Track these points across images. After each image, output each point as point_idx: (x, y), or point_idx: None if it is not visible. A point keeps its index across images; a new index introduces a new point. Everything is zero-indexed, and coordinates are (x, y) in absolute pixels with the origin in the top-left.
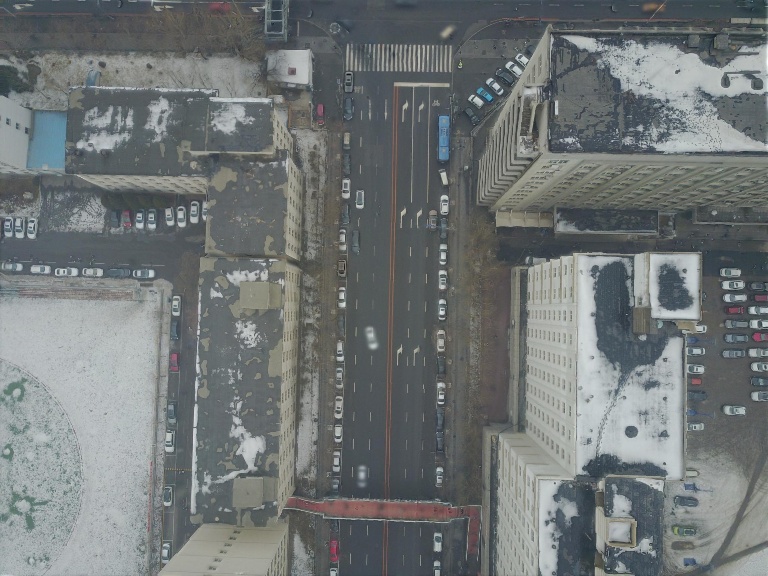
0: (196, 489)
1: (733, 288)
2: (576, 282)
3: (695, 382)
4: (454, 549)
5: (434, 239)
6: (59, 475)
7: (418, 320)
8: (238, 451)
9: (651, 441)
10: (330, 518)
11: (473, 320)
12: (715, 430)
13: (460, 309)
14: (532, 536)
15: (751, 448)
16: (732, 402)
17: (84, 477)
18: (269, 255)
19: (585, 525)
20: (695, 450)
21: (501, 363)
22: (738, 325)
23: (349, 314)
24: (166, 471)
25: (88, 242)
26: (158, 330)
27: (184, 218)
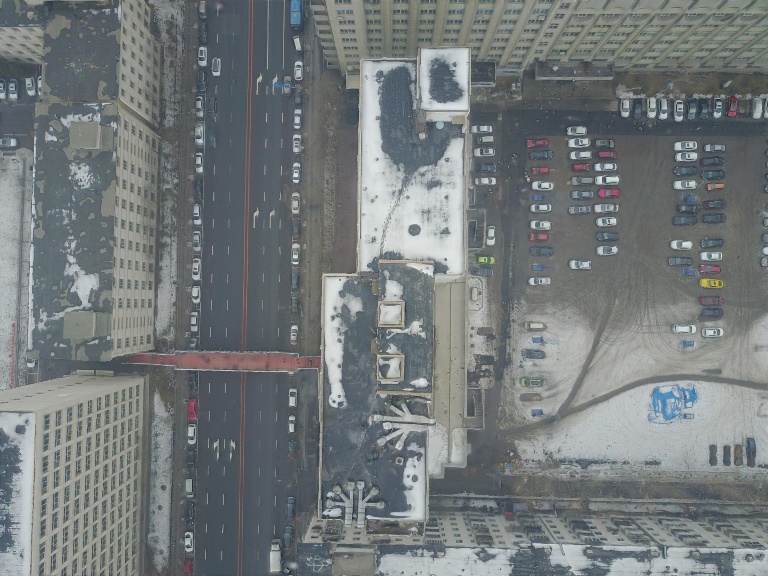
0: (32, 326)
1: (578, 145)
2: (360, 86)
3: (541, 237)
4: (309, 404)
5: (290, 105)
6: None
7: (274, 184)
8: (72, 288)
9: (433, 238)
10: (181, 369)
11: (327, 183)
12: (562, 285)
13: (314, 172)
14: None
15: (597, 302)
16: (578, 257)
17: None
18: (102, 100)
19: (370, 320)
20: (543, 304)
21: (354, 223)
22: (583, 181)
23: (207, 179)
24: None
25: None
26: (20, 197)
27: None
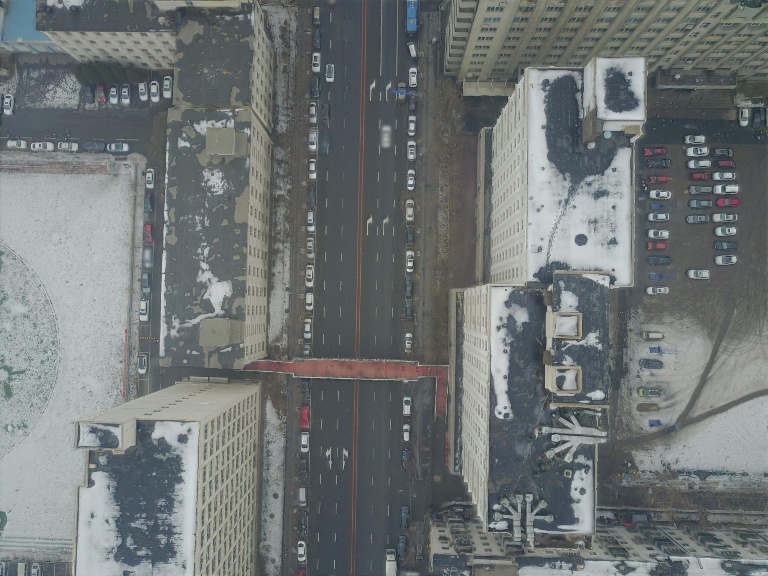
0: (165, 333)
1: (697, 154)
2: (527, 95)
3: (660, 246)
4: (423, 413)
5: (403, 112)
6: (36, 345)
7: (387, 191)
8: (205, 295)
9: (600, 248)
10: (300, 377)
11: (441, 190)
12: (680, 294)
13: (429, 179)
14: (485, 347)
15: (715, 311)
16: (696, 267)
17: (61, 346)
18: (235, 106)
19: (536, 330)
20: (660, 314)
21: (469, 231)
22: (702, 190)
23: (320, 186)
24: (141, 340)
25: (63, 118)
26: (132, 202)
27: (157, 92)
